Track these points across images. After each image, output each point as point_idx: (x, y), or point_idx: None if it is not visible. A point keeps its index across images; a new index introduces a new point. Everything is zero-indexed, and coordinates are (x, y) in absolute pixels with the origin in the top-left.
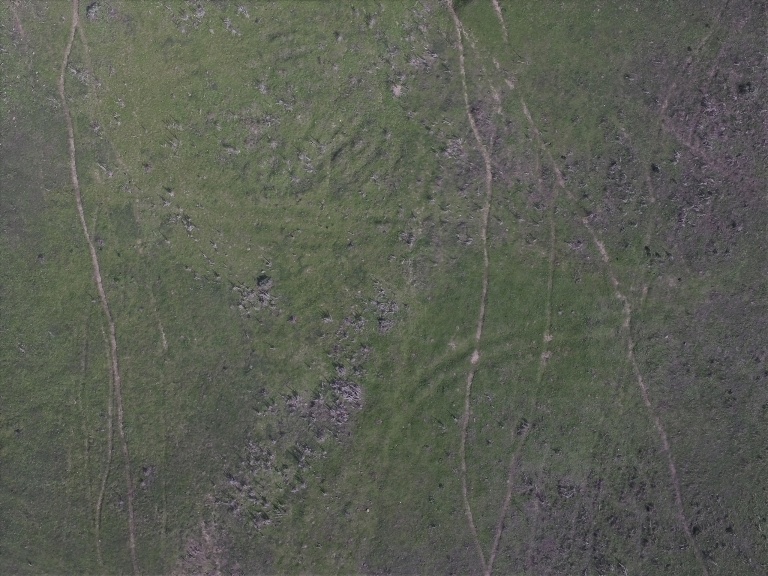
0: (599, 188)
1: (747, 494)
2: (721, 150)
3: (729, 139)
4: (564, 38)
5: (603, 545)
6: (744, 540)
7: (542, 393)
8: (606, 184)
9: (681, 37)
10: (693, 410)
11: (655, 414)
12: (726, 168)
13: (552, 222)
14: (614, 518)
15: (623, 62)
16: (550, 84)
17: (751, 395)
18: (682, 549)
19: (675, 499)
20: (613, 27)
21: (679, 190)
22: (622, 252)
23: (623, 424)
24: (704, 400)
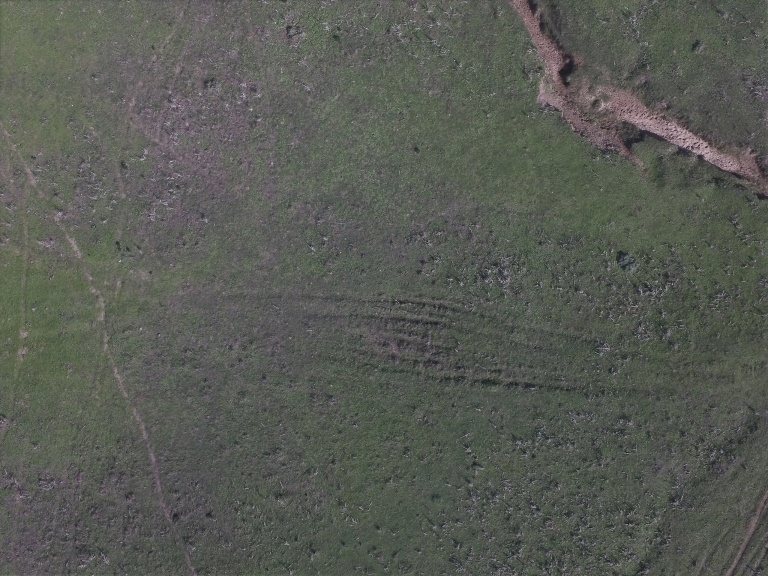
0: (70, 186)
1: (226, 480)
2: (188, 145)
3: (195, 134)
4: (29, 41)
5: (85, 535)
6: (224, 525)
7: (19, 389)
8: (77, 182)
9: (145, 37)
10: (169, 400)
11: (132, 405)
12: (194, 162)
13: (25, 221)
14: (94, 508)
15: (89, 63)
16: (18, 87)
17: (225, 383)
18: (162, 536)
19: (154, 487)
20: (77, 29)
21: (148, 185)
22: (93, 248)
23: (101, 416)
24: (180, 389)
